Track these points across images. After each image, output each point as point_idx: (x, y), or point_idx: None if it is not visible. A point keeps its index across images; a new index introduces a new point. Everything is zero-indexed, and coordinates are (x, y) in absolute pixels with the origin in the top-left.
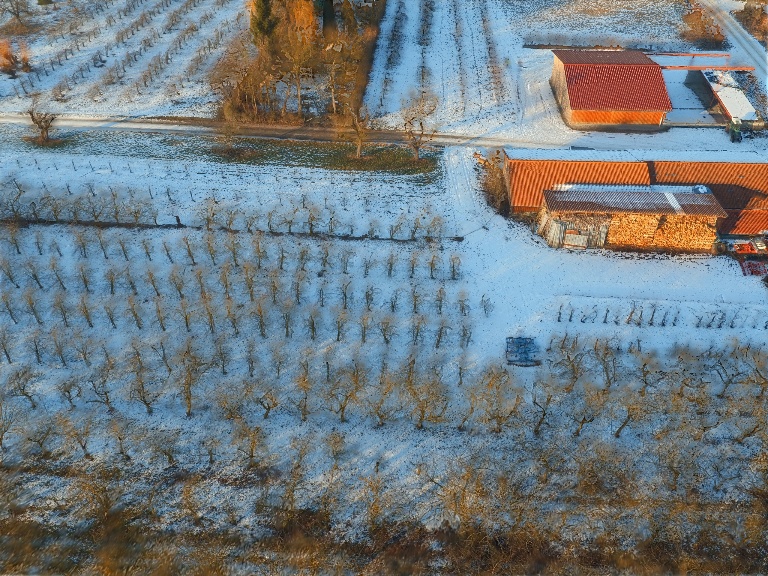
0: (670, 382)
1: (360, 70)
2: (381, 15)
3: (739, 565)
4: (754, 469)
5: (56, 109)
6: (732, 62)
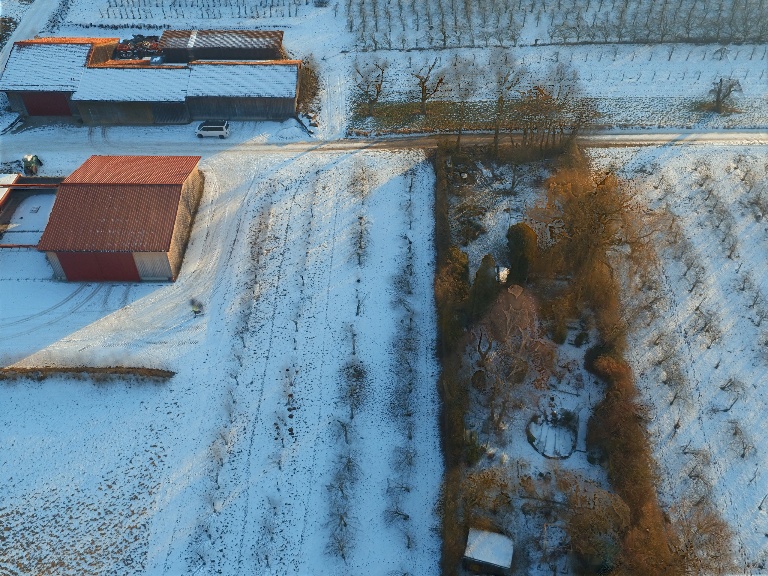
0: None
1: None
2: None
3: None
4: None
5: (761, 152)
6: None
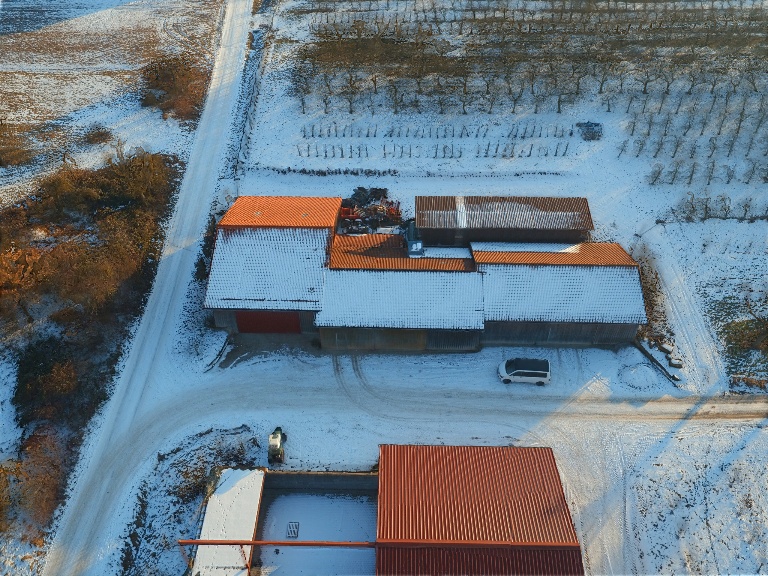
0: (494, 119)
1: None
2: None
3: None
4: None
5: None
6: None
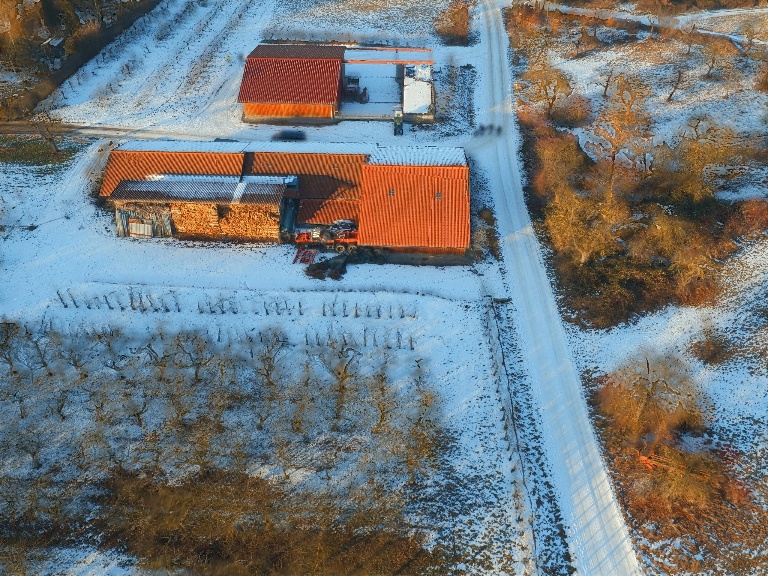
0: None
1: (63, 64)
2: (145, 11)
3: (42, 540)
4: (132, 448)
5: None
6: (464, 57)
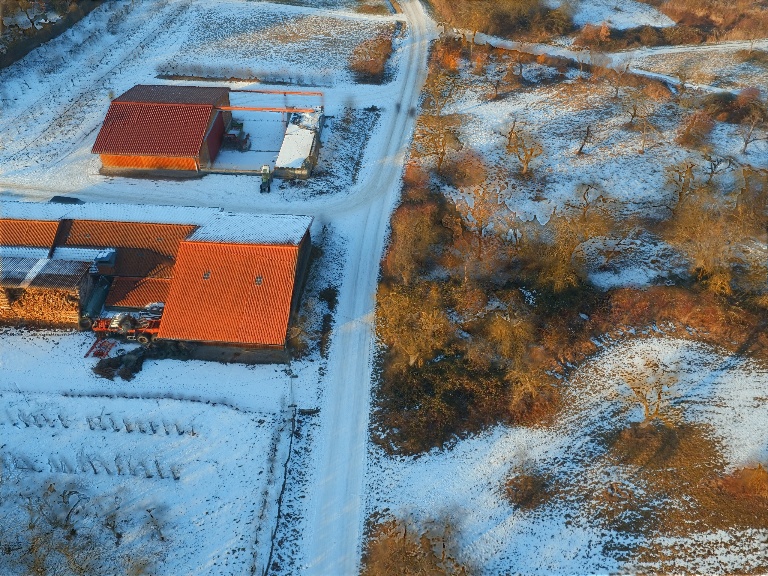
0: None
1: None
2: (47, 39)
3: None
4: None
5: None
6: (371, 98)
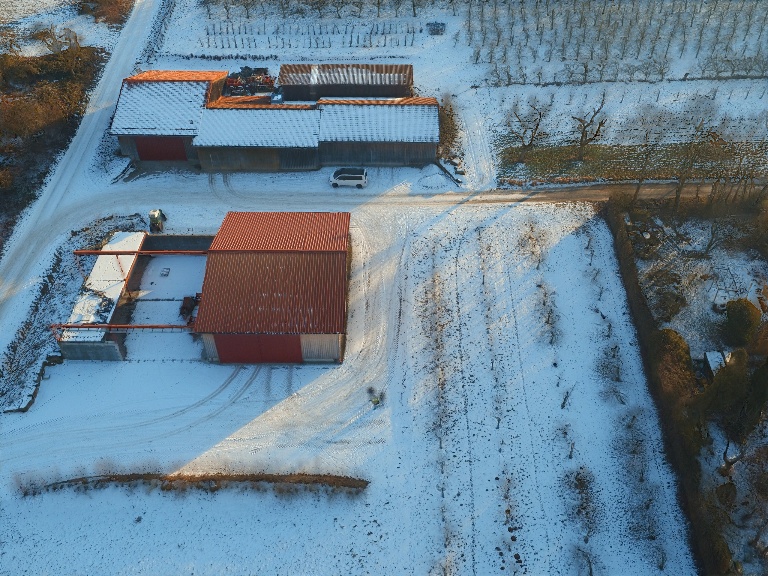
0: (362, 22)
1: None
2: None
3: None
4: None
5: None
6: None
